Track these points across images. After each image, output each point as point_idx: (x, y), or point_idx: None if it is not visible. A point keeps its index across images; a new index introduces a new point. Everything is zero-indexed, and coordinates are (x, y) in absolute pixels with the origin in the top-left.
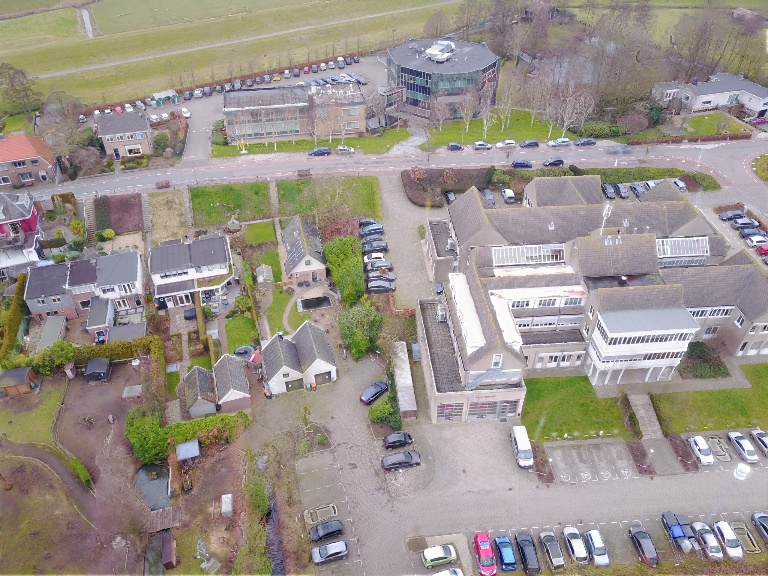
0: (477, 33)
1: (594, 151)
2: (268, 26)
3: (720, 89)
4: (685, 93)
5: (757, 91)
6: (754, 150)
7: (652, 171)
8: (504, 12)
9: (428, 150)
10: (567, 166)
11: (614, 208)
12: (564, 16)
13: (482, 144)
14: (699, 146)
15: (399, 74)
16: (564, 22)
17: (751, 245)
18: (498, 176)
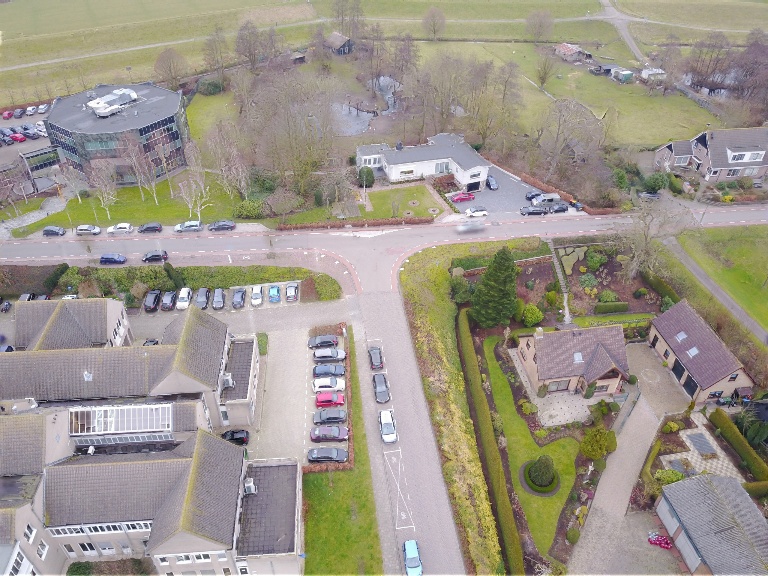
0: (252, 69)
1: (225, 239)
2: (6, 59)
3: (423, 156)
4: (383, 160)
5: (464, 160)
6: (423, 240)
7: (269, 271)
8: (251, 50)
9: (20, 235)
10: (171, 261)
11: (73, 355)
12: (358, 51)
13: (85, 229)
14: (360, 233)
15: (50, 131)
16: (360, 57)
17: (314, 390)
18: (67, 277)
